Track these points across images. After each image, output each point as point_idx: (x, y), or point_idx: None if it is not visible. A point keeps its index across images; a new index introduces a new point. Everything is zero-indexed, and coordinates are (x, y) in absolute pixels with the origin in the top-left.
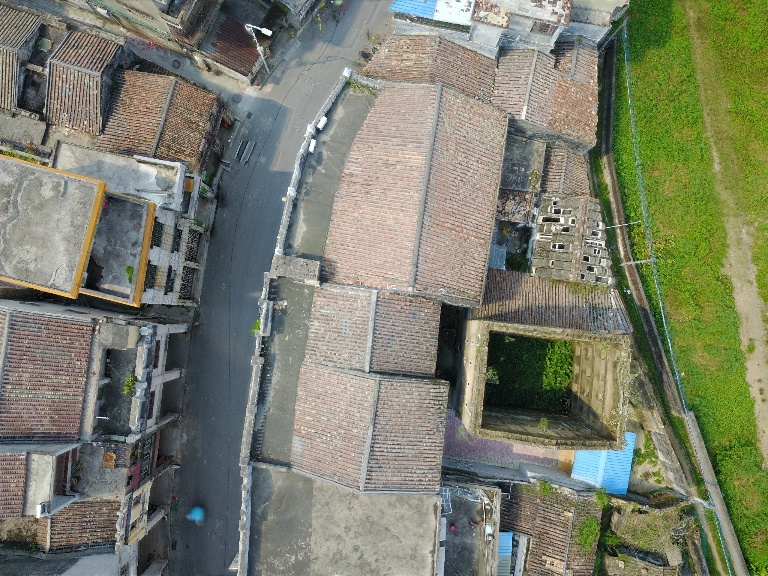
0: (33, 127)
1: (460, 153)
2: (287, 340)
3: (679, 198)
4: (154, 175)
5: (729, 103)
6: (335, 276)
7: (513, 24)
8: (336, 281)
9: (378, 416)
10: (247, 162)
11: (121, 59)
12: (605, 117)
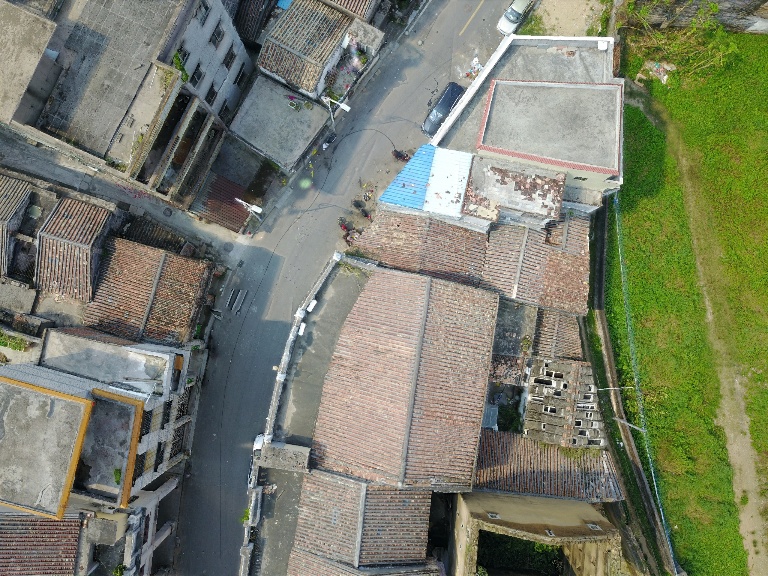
0: (23, 293)
1: (450, 340)
2: (276, 525)
3: (672, 349)
4: (143, 363)
5: (722, 252)
6: (325, 461)
7: (503, 210)
8: (326, 466)
9: None
10: (239, 311)
11: (111, 224)
12: (597, 269)
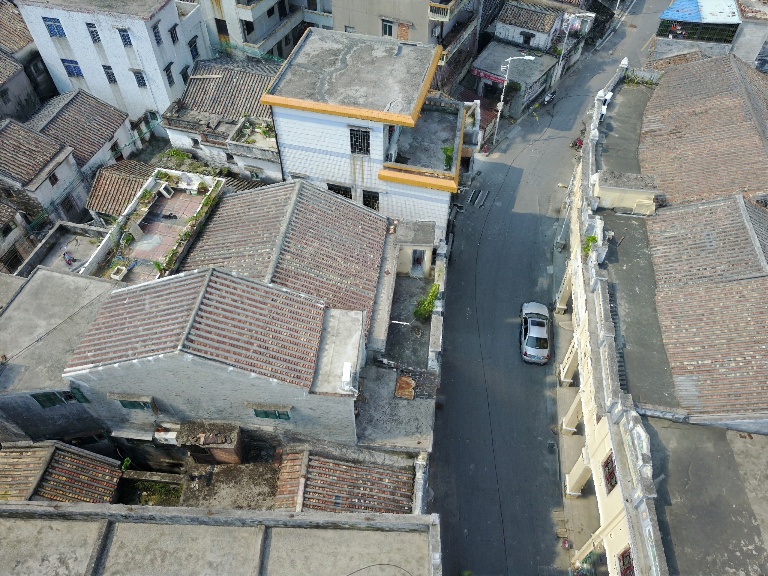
0: None
1: None
2: (625, 269)
3: None
4: None
5: None
6: None
7: None
8: None
9: None
10: (482, 205)
11: None
12: None
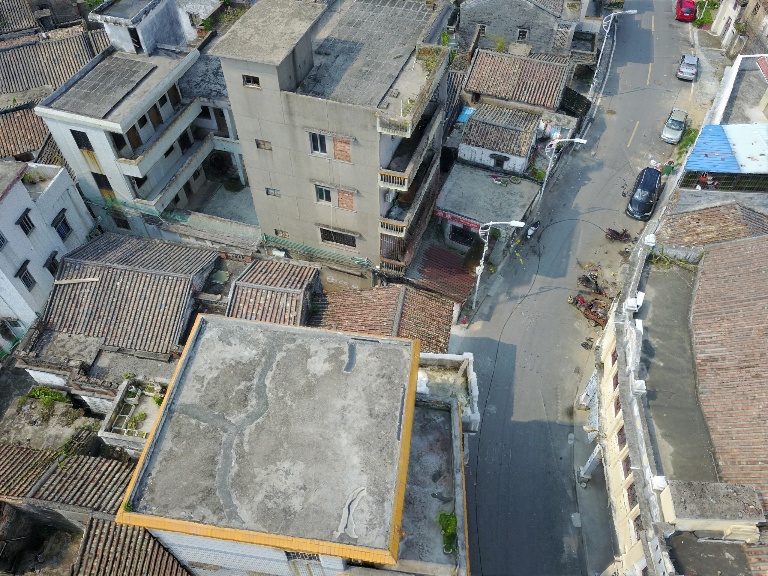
0: None
1: None
2: None
3: None
4: (424, 381)
5: None
6: None
7: None
8: None
9: None
10: None
11: (315, 287)
12: None
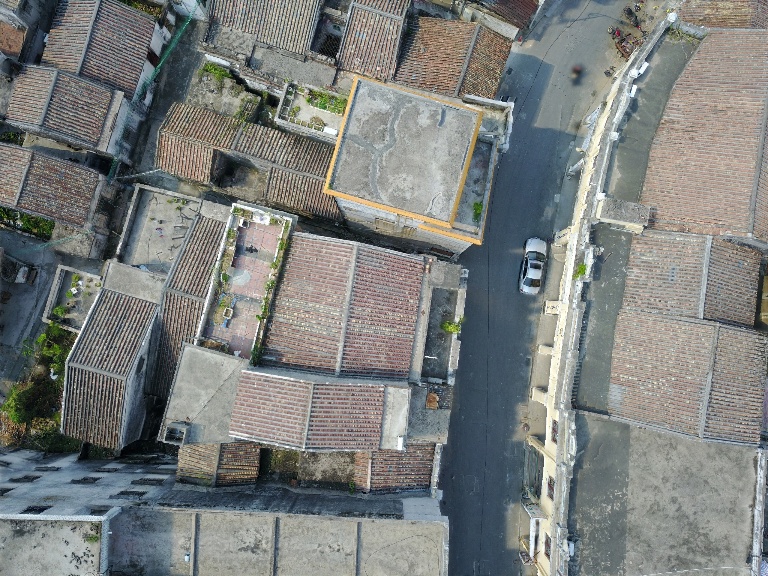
0: (323, 72)
1: None
2: (603, 287)
3: None
4: None
5: None
6: (655, 223)
7: None
8: (656, 228)
9: (716, 363)
10: None
11: None
12: None
